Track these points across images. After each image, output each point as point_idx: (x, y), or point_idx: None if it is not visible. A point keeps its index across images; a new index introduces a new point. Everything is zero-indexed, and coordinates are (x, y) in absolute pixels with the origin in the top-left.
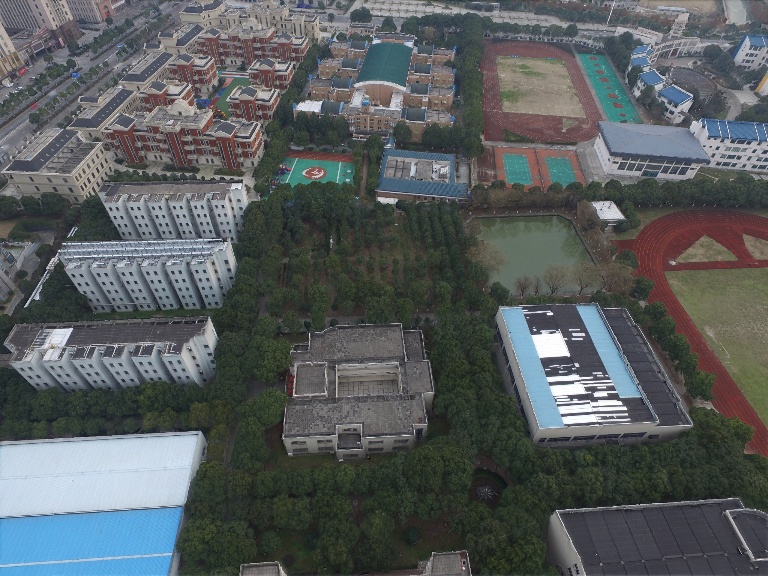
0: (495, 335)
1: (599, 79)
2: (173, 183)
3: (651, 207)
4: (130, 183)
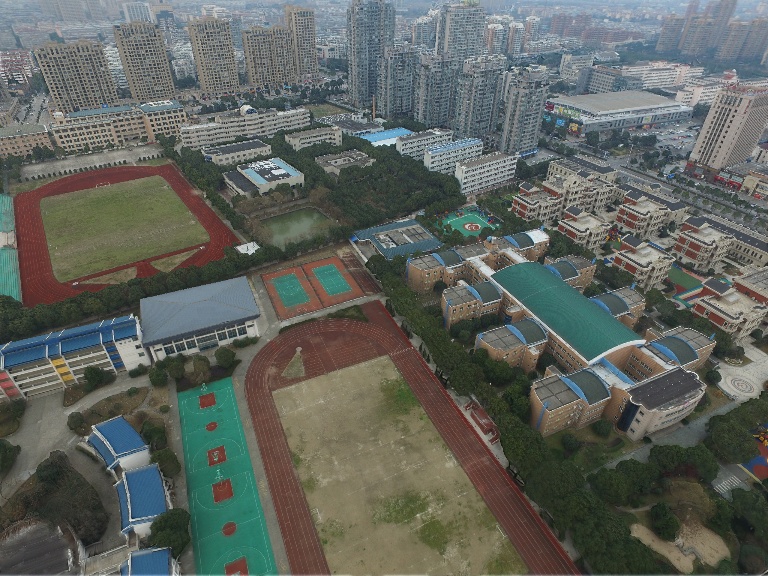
0: None
1: (251, 567)
2: (493, 162)
3: None
4: None
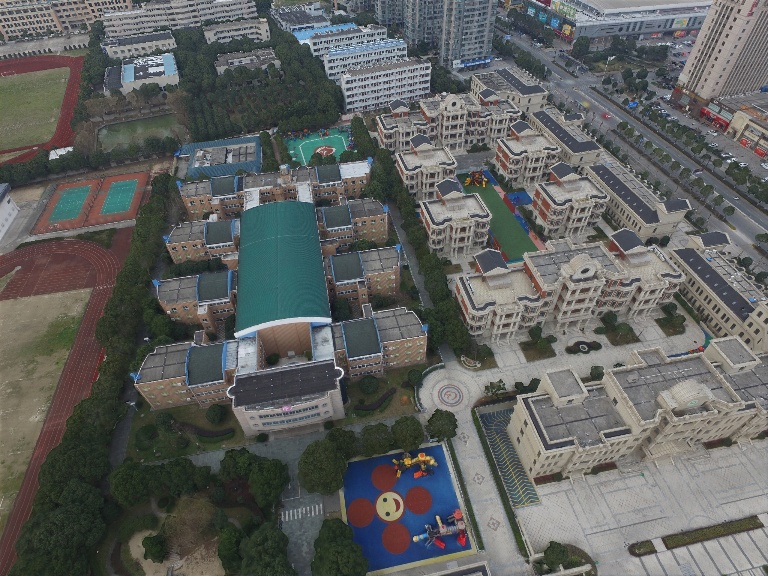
0: None
1: None
2: (390, 71)
3: None
4: (416, 66)
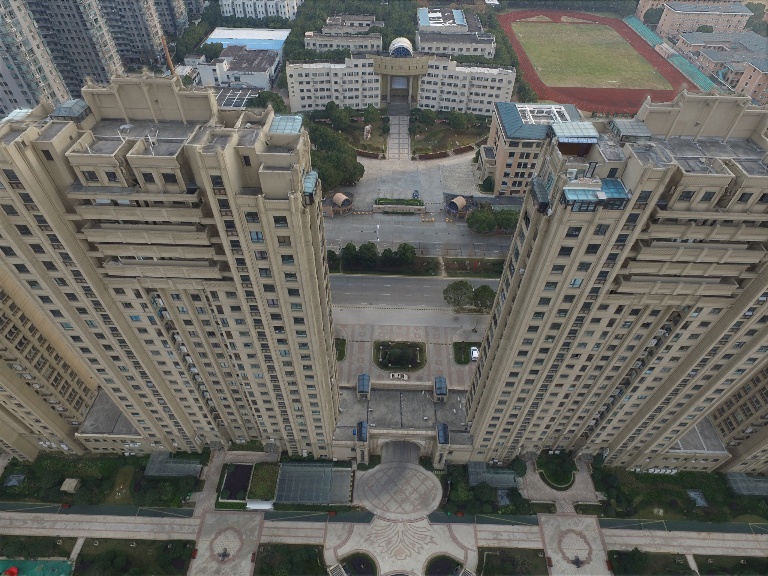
0: (416, 23)
1: None
2: None
3: (520, 7)
4: None
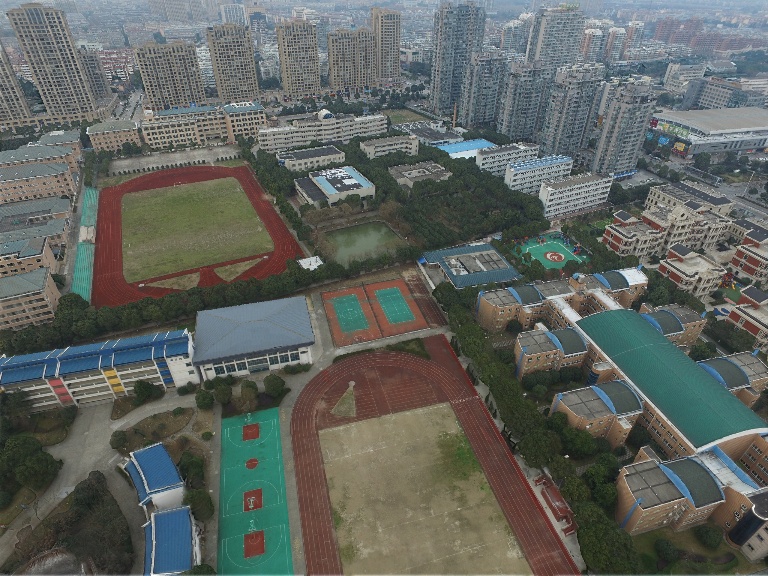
0: None
1: None
2: (583, 184)
3: None
4: (603, 180)
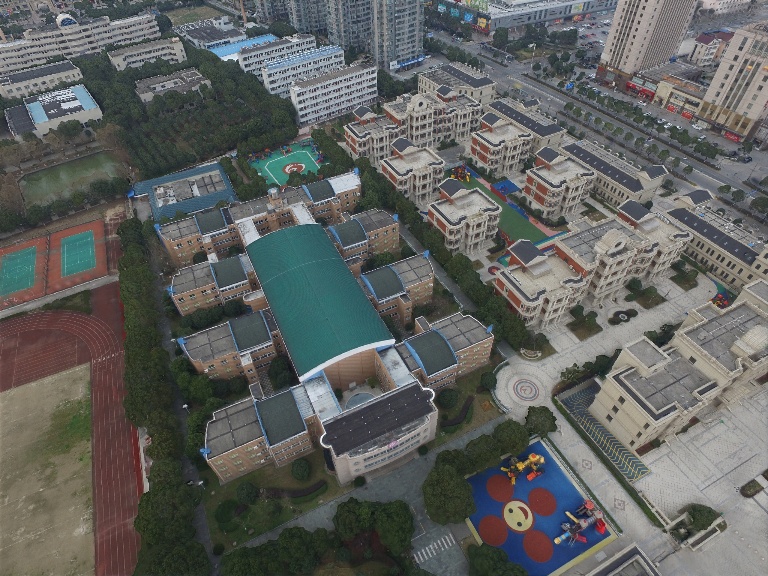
0: None
1: None
2: (339, 79)
3: None
4: (363, 71)
